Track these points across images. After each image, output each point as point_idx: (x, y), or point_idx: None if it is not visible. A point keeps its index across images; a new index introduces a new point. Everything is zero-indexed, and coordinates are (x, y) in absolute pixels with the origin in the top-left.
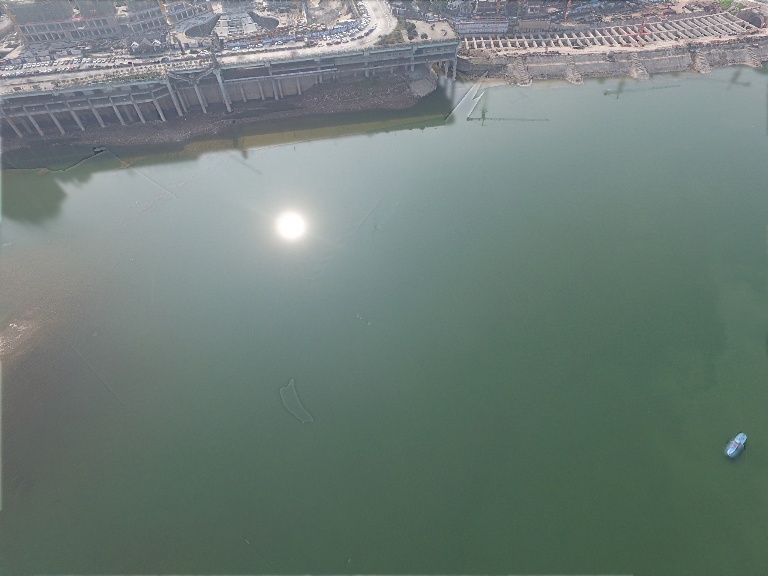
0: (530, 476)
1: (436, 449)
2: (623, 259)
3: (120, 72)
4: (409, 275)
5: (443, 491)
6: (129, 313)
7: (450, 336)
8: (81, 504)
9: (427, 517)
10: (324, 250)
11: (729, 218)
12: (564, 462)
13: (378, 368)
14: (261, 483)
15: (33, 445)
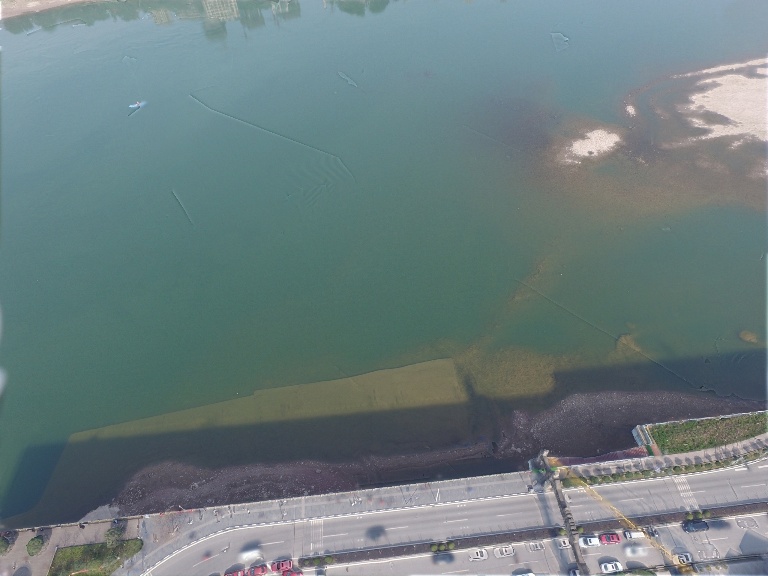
0: (244, 93)
1: (285, 111)
2: (88, 186)
3: (761, 455)
4: None
5: (287, 100)
6: (492, 169)
7: None
8: (461, 94)
9: (298, 95)
10: (333, 182)
11: None
12: (226, 94)
13: (307, 137)
14: (375, 101)
15: (504, 112)
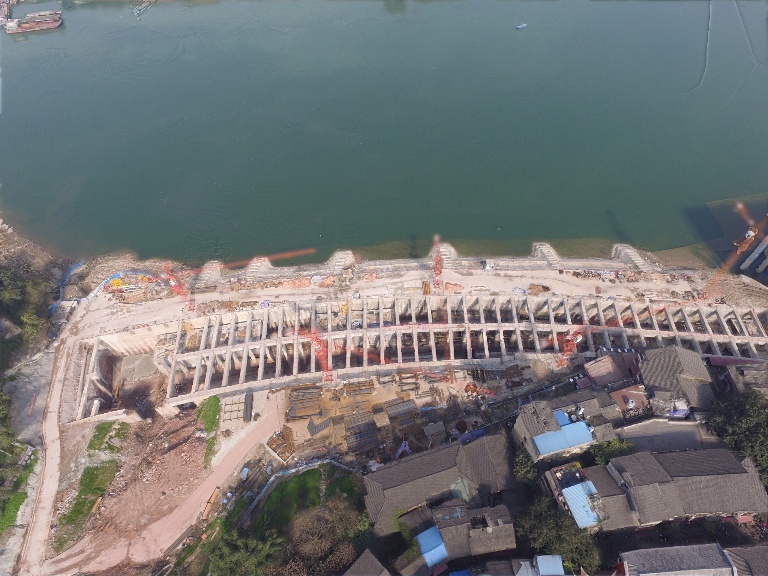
0: (609, 16)
1: (646, 30)
2: (547, 74)
3: None
4: (688, 79)
5: (640, 23)
6: None
7: (649, 62)
8: None
9: (644, 20)
10: None
11: (459, 95)
12: (596, 16)
13: None
14: None
15: None
